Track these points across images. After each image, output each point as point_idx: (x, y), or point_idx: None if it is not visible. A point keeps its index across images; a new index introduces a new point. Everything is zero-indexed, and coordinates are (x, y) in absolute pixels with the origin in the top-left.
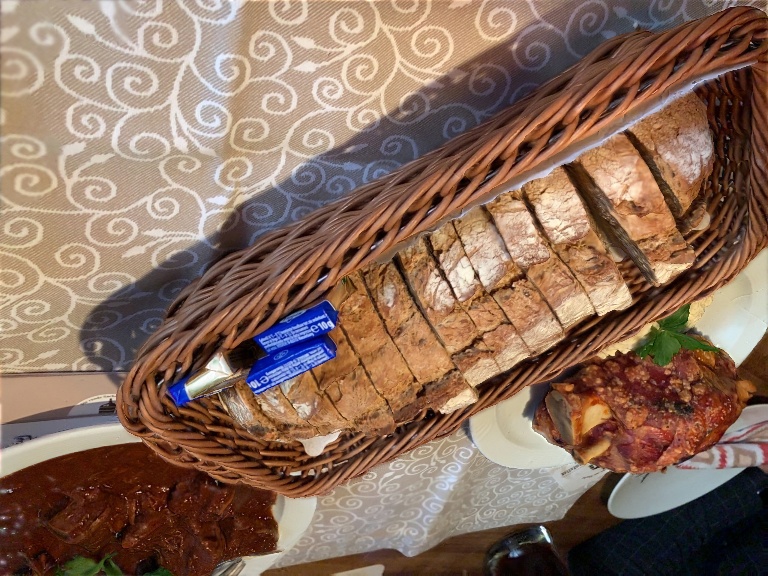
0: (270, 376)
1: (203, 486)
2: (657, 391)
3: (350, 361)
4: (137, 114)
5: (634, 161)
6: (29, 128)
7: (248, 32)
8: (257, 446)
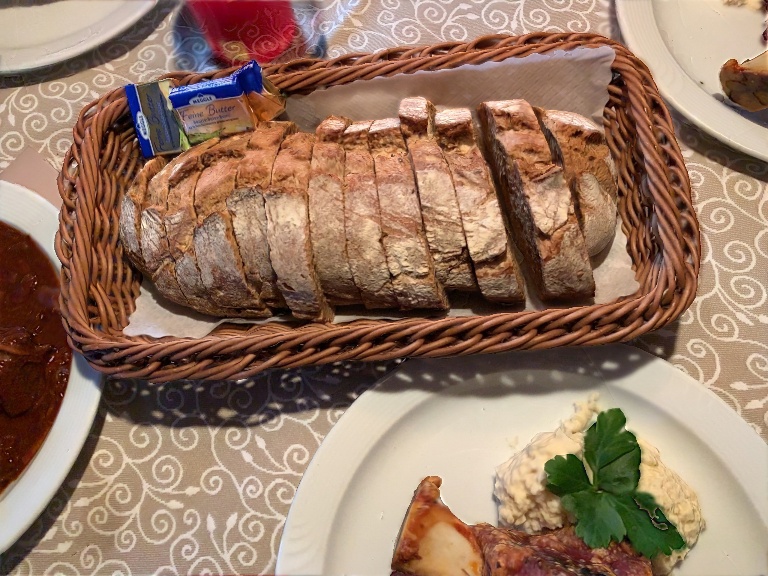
0: (188, 87)
1: (19, 328)
2: (564, 556)
3: (239, 146)
4: (256, 55)
5: (519, 100)
6: (209, 39)
7: (332, 42)
8: (104, 272)
